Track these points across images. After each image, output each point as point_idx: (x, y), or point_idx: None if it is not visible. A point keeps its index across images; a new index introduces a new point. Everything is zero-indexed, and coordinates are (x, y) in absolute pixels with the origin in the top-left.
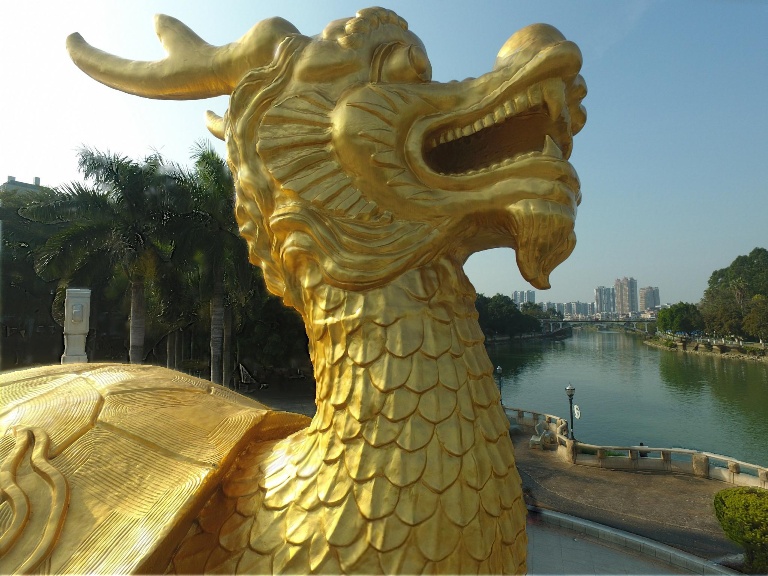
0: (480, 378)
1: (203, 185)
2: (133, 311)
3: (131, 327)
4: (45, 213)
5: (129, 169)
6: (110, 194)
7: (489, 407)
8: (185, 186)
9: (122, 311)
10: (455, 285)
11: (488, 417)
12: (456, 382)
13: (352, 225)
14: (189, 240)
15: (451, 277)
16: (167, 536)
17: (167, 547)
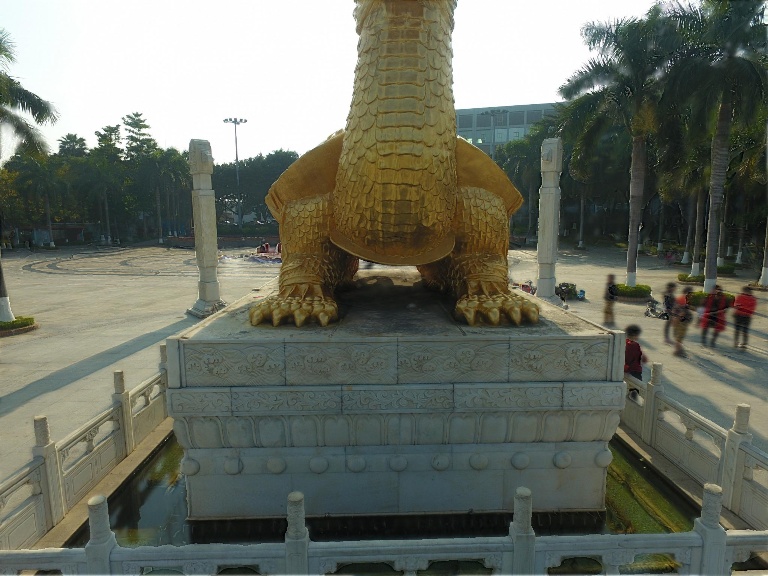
0: (386, 57)
1: (706, 11)
2: (633, 164)
3: (631, 179)
4: (570, 91)
5: (628, 26)
6: (612, 57)
7: (390, 71)
8: (672, 21)
9: (624, 165)
10: (385, 15)
11: (385, 75)
12: (369, 61)
13: (358, 6)
14: (678, 80)
15: (383, 11)
16: (330, 140)
17: (335, 147)
